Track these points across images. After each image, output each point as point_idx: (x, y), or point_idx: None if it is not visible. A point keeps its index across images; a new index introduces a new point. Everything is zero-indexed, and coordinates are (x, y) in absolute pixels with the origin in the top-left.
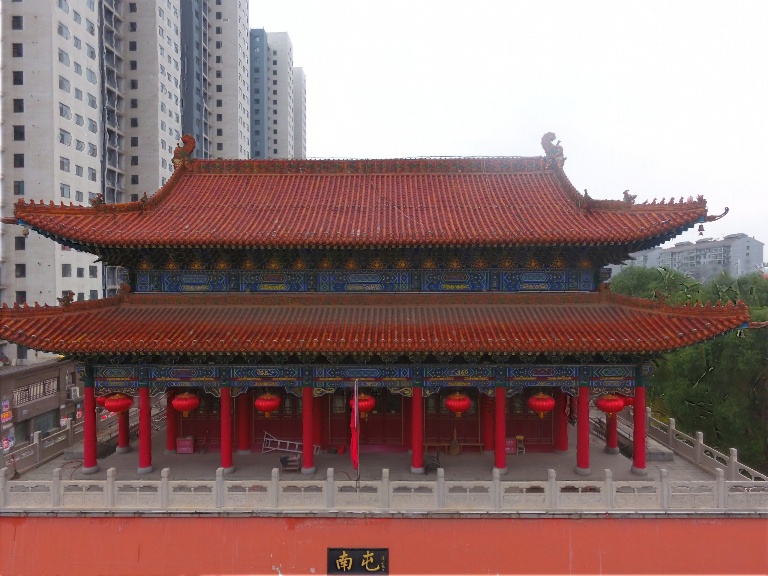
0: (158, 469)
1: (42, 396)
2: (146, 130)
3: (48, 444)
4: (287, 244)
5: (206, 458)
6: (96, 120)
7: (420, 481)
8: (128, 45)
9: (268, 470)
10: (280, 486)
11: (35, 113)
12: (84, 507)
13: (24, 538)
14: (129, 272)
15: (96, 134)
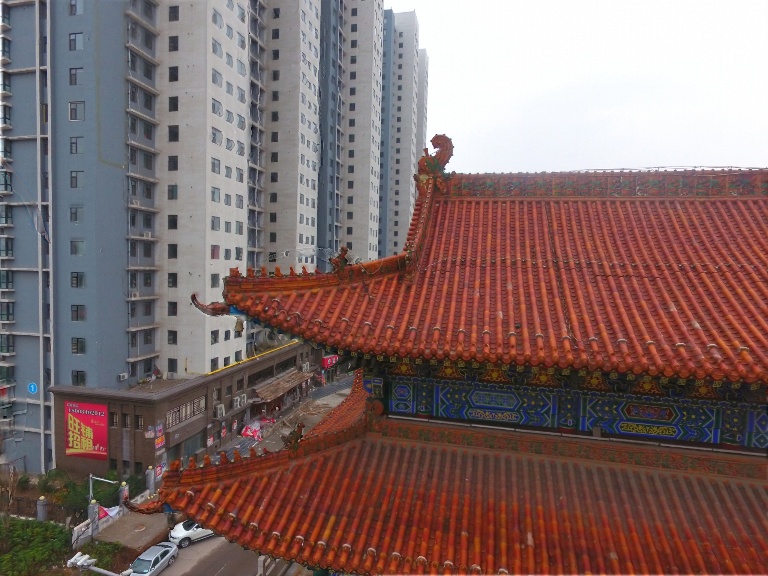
0: None
1: (191, 416)
2: (286, 124)
3: None
4: (766, 382)
5: None
6: (244, 116)
7: None
8: (271, 33)
9: None
10: None
11: (189, 111)
12: None
13: None
14: (383, 382)
15: (244, 131)
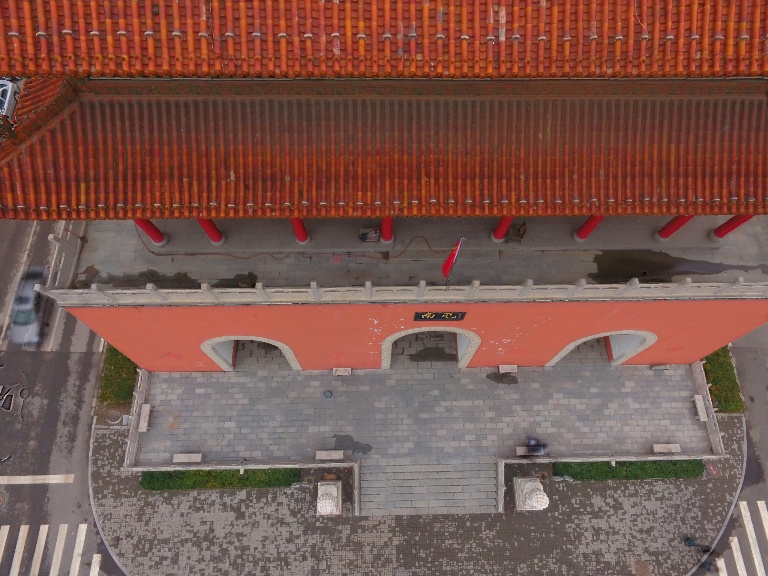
0: (229, 234)
1: None
2: None
3: None
4: (368, 76)
5: None
6: None
7: (507, 286)
8: None
9: (344, 234)
10: (373, 290)
11: None
12: (192, 301)
13: (150, 312)
14: None
15: None
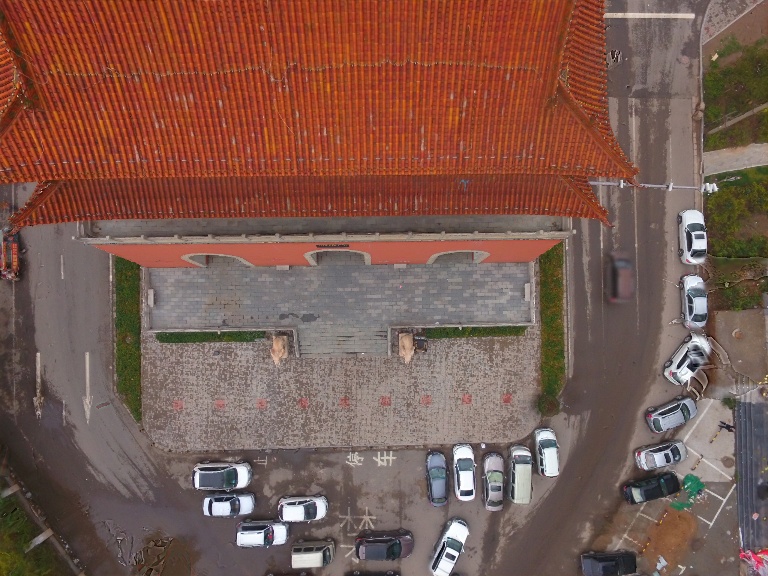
0: None
1: None
2: None
3: (766, 446)
4: None
5: None
6: None
7: None
8: None
9: None
10: None
11: None
12: None
13: None
14: None
15: None
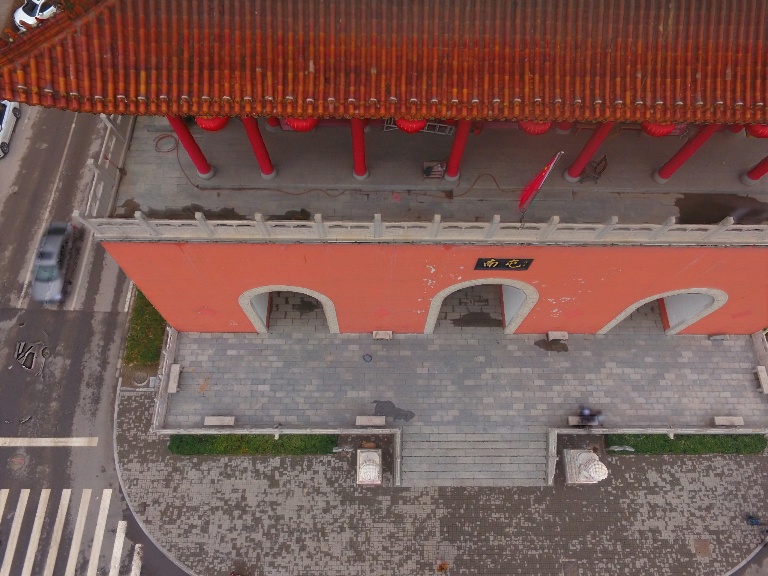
0: (280, 168)
1: None
2: None
3: None
4: None
5: (323, 142)
6: None
7: (588, 224)
8: None
9: (404, 170)
10: (441, 226)
11: None
12: (241, 237)
13: (192, 252)
14: None
15: None
